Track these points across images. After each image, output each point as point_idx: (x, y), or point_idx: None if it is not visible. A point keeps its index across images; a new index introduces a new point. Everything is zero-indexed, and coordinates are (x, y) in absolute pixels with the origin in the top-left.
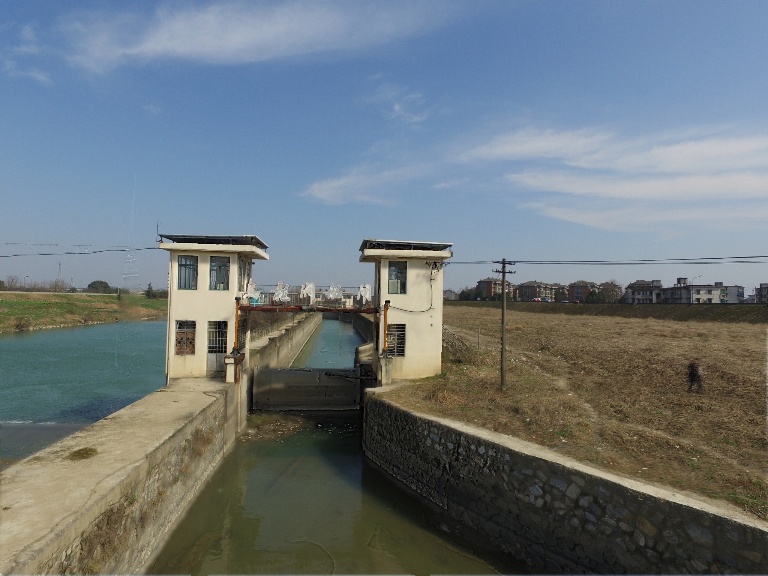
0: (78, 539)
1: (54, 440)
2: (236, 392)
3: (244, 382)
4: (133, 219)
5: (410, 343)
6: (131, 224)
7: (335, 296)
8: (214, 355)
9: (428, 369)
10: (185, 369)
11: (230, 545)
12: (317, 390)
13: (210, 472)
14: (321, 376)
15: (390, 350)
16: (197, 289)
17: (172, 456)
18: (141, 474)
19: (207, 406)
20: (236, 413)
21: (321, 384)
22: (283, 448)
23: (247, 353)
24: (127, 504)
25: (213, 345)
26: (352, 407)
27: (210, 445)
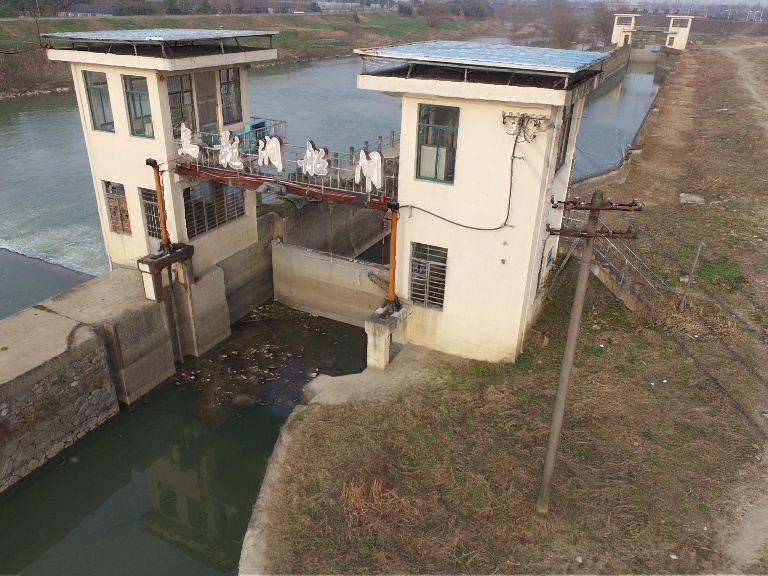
0: None
1: (28, 306)
2: (186, 303)
3: (208, 284)
4: None
5: (454, 288)
6: None
7: (316, 170)
8: (156, 241)
9: (488, 346)
10: (126, 254)
11: (213, 478)
12: (357, 297)
13: (63, 451)
14: (363, 277)
15: (417, 291)
16: (115, 132)
17: None
18: None
19: (17, 377)
20: (190, 331)
21: (363, 289)
22: None
23: (247, 224)
24: None
25: (152, 225)
26: None
27: (47, 422)
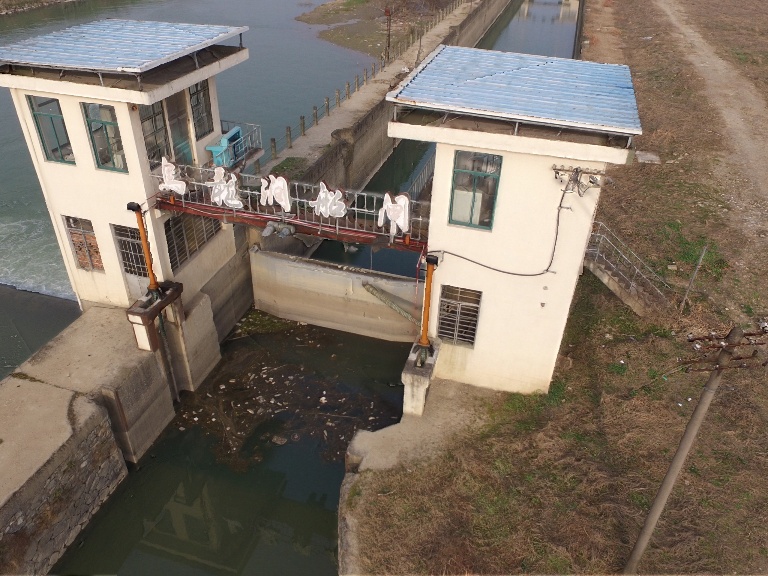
0: None
1: None
2: (177, 341)
3: (197, 316)
4: None
5: (488, 328)
6: None
7: (331, 211)
8: (135, 278)
9: (520, 379)
10: (98, 291)
11: (213, 497)
12: (350, 305)
13: (80, 533)
14: (356, 285)
15: (445, 329)
16: (76, 165)
17: None
18: None
19: (27, 480)
20: (184, 368)
21: (357, 297)
22: None
23: (225, 238)
24: None
25: (130, 262)
26: (410, 339)
27: (62, 512)
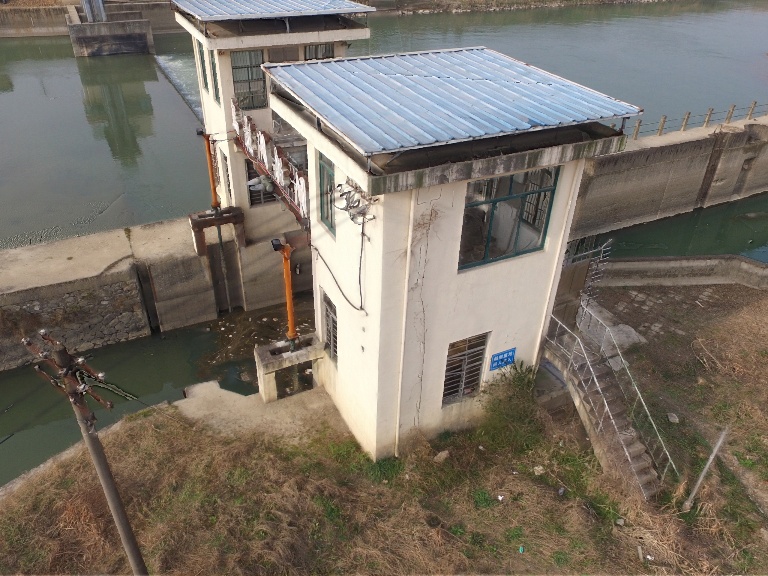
0: None
1: None
2: (238, 261)
3: (263, 251)
4: None
5: (342, 353)
6: None
7: (280, 178)
8: None
9: (361, 430)
10: None
11: None
12: None
13: (92, 349)
14: None
15: None
16: None
17: None
18: None
19: (49, 285)
20: None
21: None
22: (191, 372)
23: None
24: None
25: None
26: None
27: (77, 324)
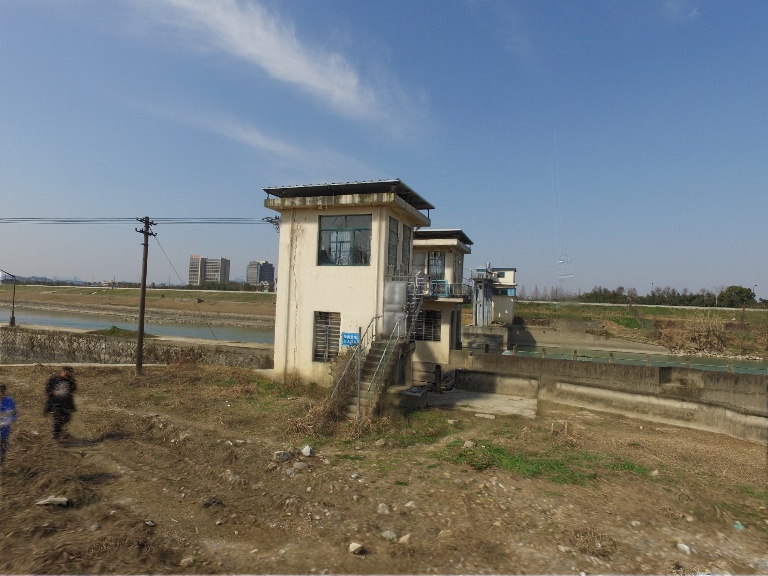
0: (180, 348)
1: None
2: None
3: None
4: (560, 219)
5: None
6: (559, 225)
7: None
8: None
9: None
10: None
11: None
12: None
13: None
14: None
15: None
16: None
17: (240, 356)
18: (211, 348)
19: None
20: None
21: None
22: None
23: (439, 348)
24: (203, 354)
25: None
26: None
27: None
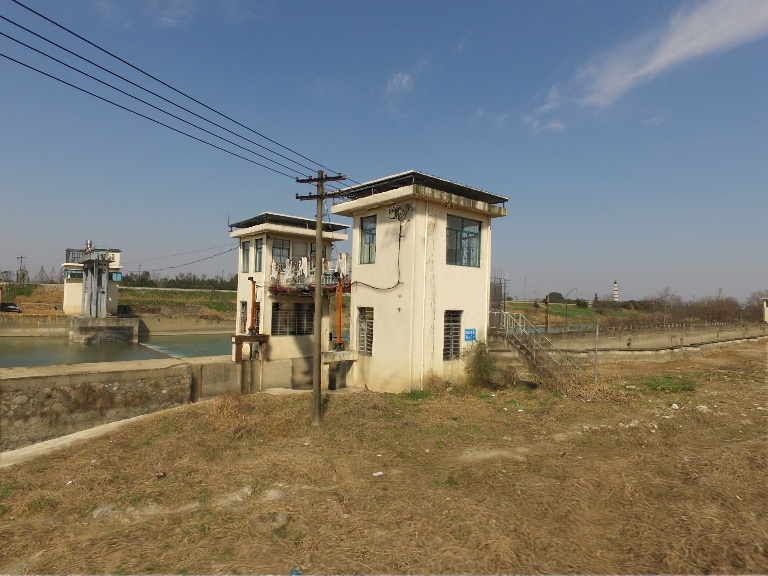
0: None
1: None
2: (259, 374)
3: (277, 366)
4: None
5: (377, 337)
6: None
7: None
8: None
9: (395, 381)
10: None
11: None
12: None
13: None
14: None
15: (362, 345)
16: (249, 272)
17: (16, 395)
18: None
19: (130, 370)
20: None
21: None
22: None
23: None
24: None
25: None
26: None
27: (139, 408)
